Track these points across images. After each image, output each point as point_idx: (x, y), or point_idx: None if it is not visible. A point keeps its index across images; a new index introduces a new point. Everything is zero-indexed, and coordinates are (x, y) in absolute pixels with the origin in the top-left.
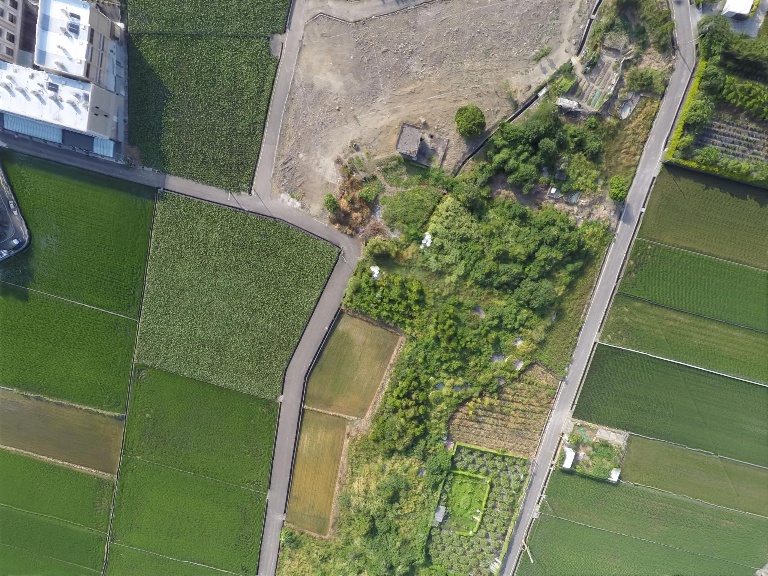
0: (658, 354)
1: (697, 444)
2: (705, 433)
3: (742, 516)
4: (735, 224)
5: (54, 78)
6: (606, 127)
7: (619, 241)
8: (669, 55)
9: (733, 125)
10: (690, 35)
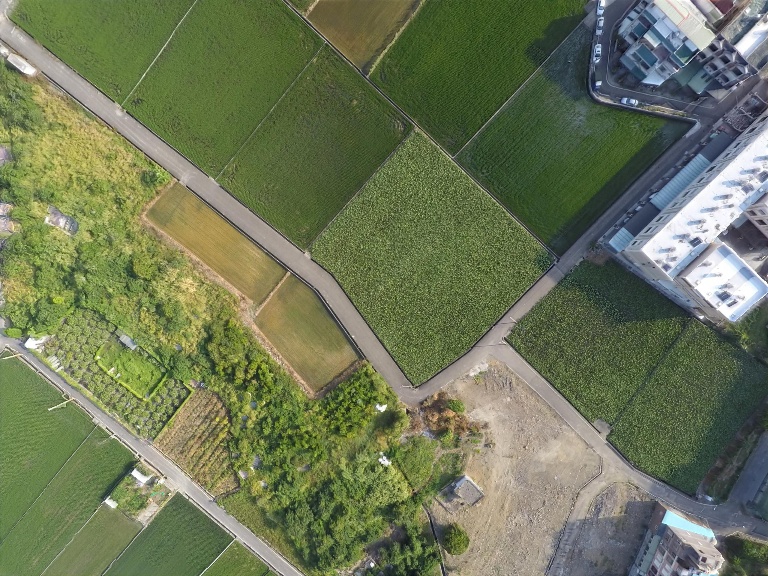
0: (206, 574)
1: (116, 568)
2: None
3: (38, 573)
4: None
5: (702, 248)
6: None
7: None
8: None
9: None
10: None
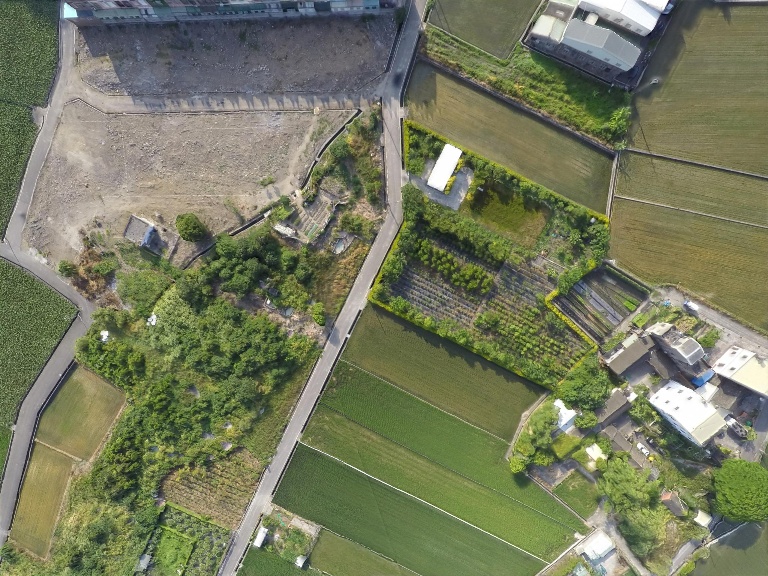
0: (351, 464)
1: (380, 549)
2: (387, 541)
3: None
4: (427, 366)
5: None
6: (318, 258)
7: (325, 358)
8: (380, 208)
9: (431, 281)
10: (400, 195)
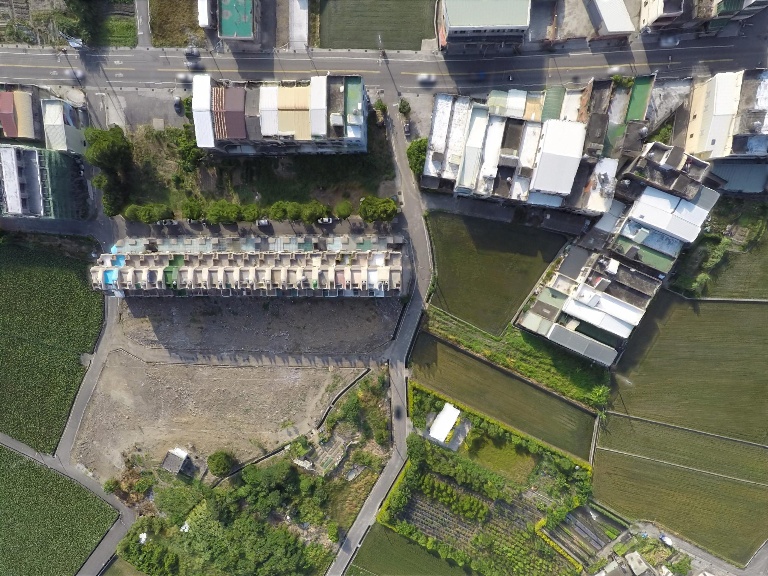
0: None
1: None
2: None
3: None
4: (429, 573)
5: None
6: (332, 485)
7: (338, 562)
8: (387, 447)
9: (433, 506)
10: (405, 438)
